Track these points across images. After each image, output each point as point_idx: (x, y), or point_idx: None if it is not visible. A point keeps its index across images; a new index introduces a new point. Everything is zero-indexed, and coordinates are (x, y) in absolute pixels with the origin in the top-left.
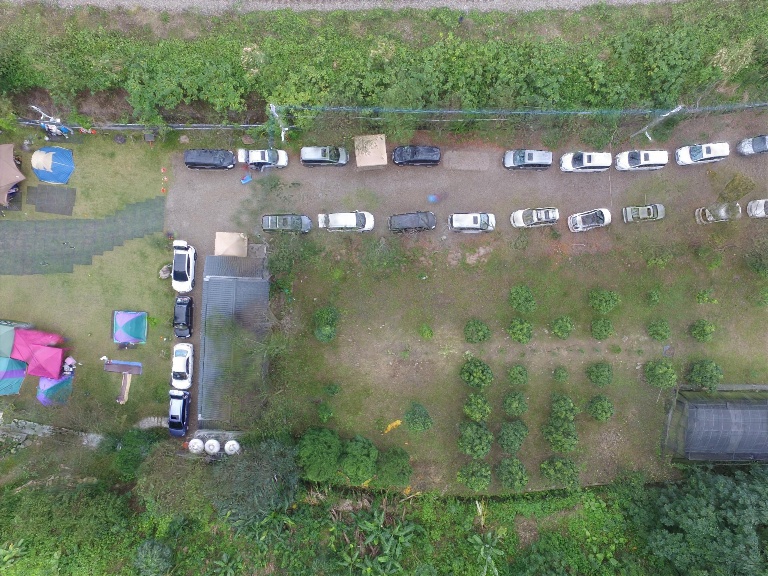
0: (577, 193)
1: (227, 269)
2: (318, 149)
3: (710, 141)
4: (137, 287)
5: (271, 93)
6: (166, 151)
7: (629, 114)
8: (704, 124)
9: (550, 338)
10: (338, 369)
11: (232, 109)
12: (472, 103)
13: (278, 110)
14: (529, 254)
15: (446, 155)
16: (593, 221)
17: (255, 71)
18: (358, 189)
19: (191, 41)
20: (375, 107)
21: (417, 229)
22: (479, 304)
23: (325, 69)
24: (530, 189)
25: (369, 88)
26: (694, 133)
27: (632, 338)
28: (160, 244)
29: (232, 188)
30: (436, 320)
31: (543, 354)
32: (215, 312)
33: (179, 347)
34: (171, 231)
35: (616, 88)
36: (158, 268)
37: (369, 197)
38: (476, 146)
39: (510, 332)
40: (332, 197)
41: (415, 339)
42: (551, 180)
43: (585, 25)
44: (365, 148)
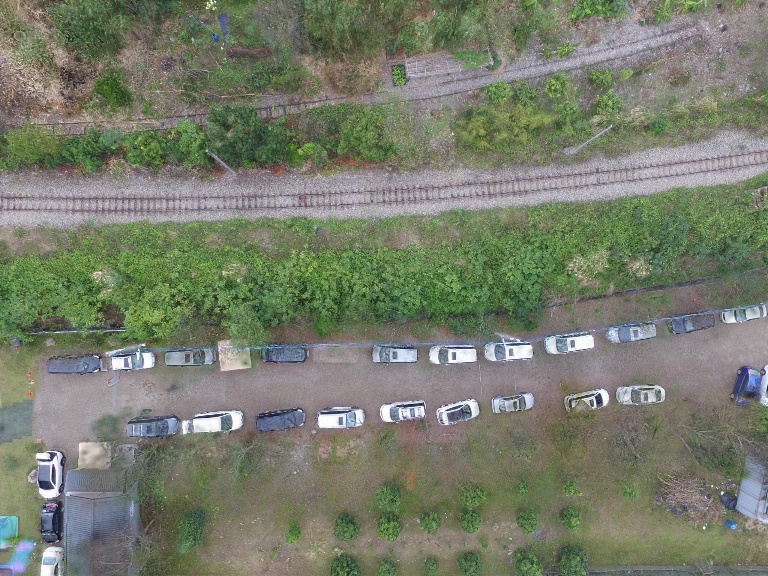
0: (447, 383)
1: (86, 487)
2: (182, 355)
3: (579, 327)
4: (7, 491)
5: (128, 308)
6: (33, 354)
7: (496, 306)
8: (573, 310)
9: (421, 529)
10: (210, 566)
11: (88, 327)
12: (332, 310)
13: (135, 326)
14: (400, 445)
15: (316, 348)
16: (459, 418)
17: (108, 291)
18: (228, 385)
19: (46, 257)
20: (233, 319)
21: (284, 429)
22: (351, 496)
23: (183, 281)
24: (400, 380)
25: (224, 304)
26: (563, 320)
27: (503, 526)
28: (29, 448)
29: (100, 389)
30: (308, 513)
31: (414, 545)
32: (75, 531)
33: (47, 554)
34: (39, 434)
35: (474, 293)
36: (27, 472)
37: (239, 393)
38: (345, 339)
39: (377, 530)
40: (201, 394)
41: (286, 534)
42: (421, 371)
43: (443, 230)
44: (227, 355)
